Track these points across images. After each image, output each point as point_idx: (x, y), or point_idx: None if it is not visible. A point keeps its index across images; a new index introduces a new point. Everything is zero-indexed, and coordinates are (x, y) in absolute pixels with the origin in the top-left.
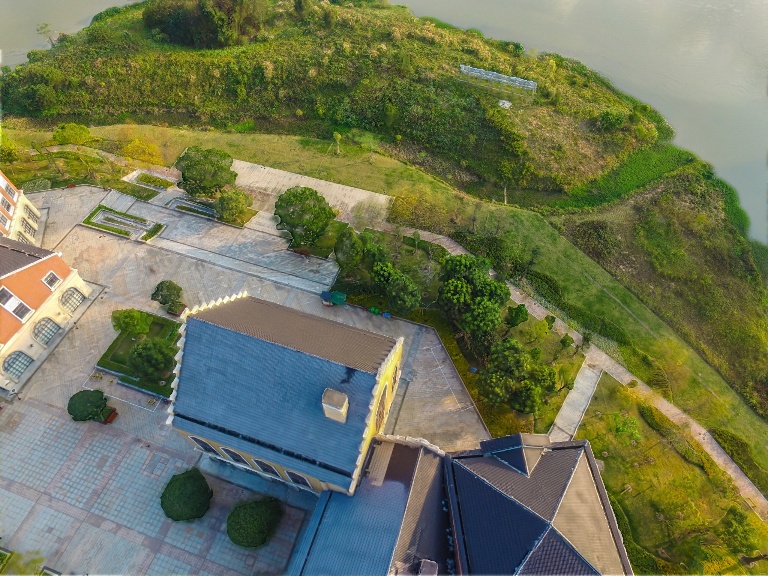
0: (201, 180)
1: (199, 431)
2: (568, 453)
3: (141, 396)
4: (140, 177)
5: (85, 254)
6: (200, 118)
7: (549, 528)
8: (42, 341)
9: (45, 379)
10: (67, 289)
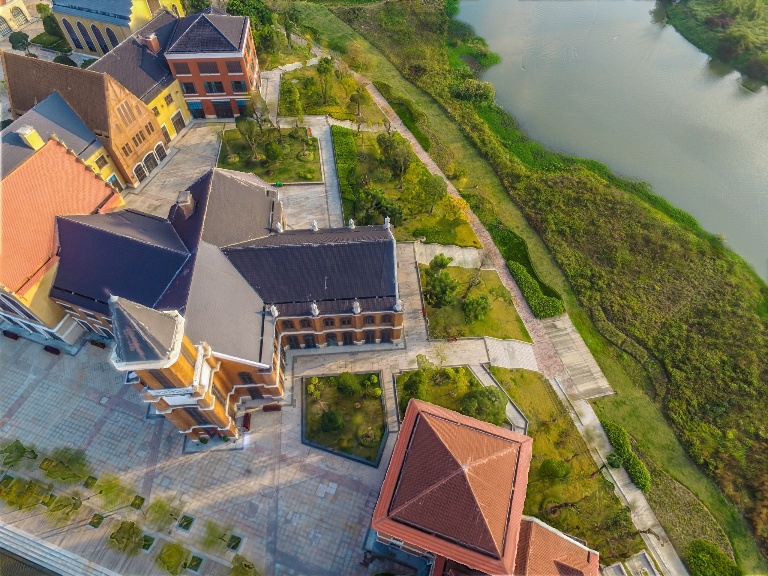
0: None
1: (65, 11)
2: None
3: (53, 54)
4: None
5: (31, 7)
6: None
7: (201, 15)
8: (0, 33)
9: (1, 47)
10: (16, 8)
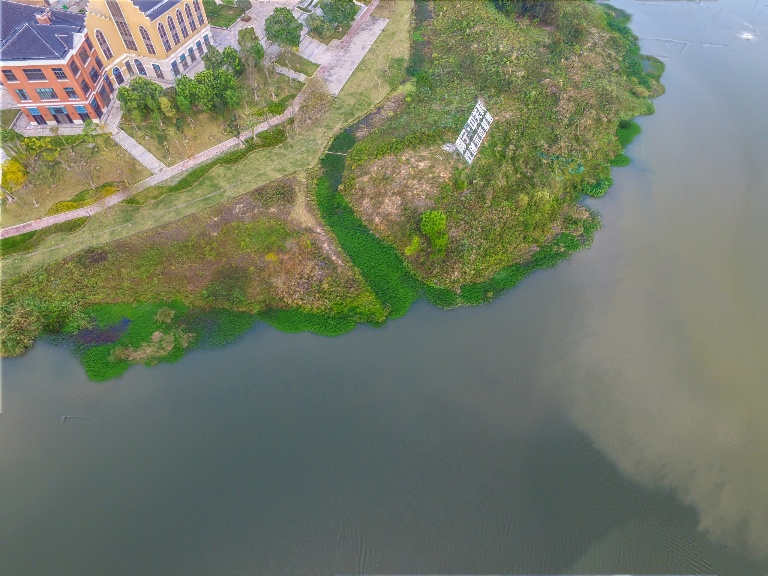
0: (323, 1)
1: None
2: (60, 51)
3: None
4: (358, 6)
5: None
6: (425, 21)
7: None
8: None
9: None
10: None
